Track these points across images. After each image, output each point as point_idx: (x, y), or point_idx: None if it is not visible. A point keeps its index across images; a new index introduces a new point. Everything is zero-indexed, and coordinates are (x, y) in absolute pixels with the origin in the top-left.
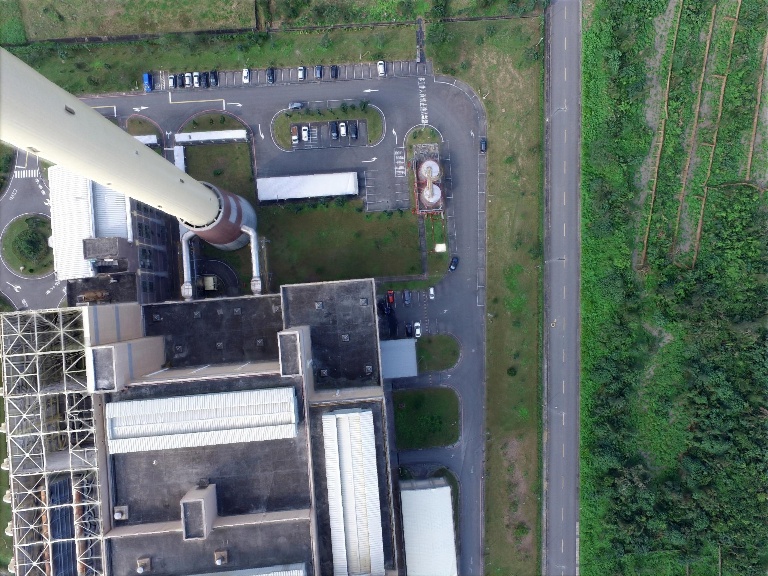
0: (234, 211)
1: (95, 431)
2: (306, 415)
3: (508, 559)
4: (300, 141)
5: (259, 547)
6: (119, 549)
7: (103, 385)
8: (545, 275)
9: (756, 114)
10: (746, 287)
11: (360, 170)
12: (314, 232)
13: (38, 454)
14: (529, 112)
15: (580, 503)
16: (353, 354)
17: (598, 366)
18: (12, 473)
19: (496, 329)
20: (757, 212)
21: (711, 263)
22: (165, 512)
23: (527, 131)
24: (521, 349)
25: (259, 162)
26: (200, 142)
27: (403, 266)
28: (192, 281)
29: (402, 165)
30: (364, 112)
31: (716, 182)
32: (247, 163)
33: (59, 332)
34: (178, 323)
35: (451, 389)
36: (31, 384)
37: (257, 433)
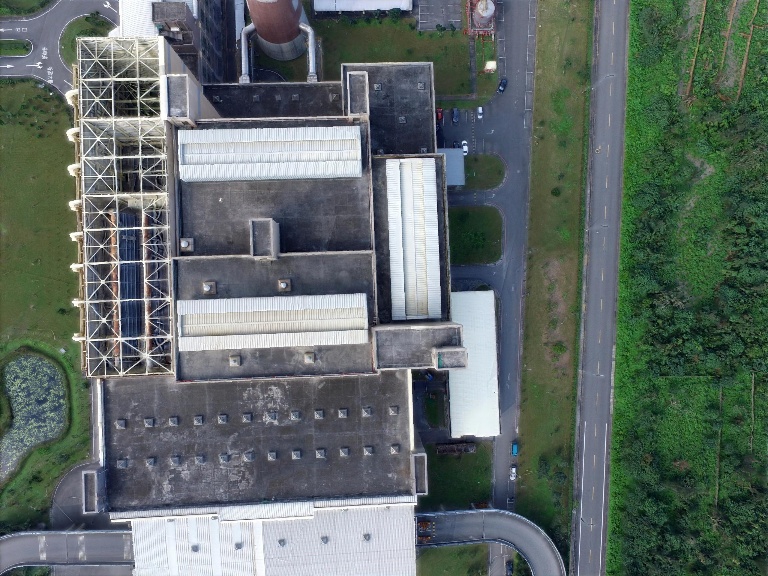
0: None
1: (166, 158)
2: (370, 160)
3: (545, 376)
4: None
5: (321, 279)
6: (185, 273)
7: (176, 113)
8: (591, 102)
9: None
10: None
11: None
12: (367, 47)
13: (110, 176)
14: None
15: (617, 326)
16: (409, 137)
17: (640, 191)
18: (84, 193)
19: (542, 151)
20: None
21: (755, 96)
22: (229, 248)
23: None
24: (565, 172)
25: None
26: None
27: (453, 85)
28: (249, 76)
29: None
30: None
31: (762, 22)
32: None
33: (135, 60)
34: (237, 106)
35: (495, 208)
36: (106, 108)
37: (324, 167)
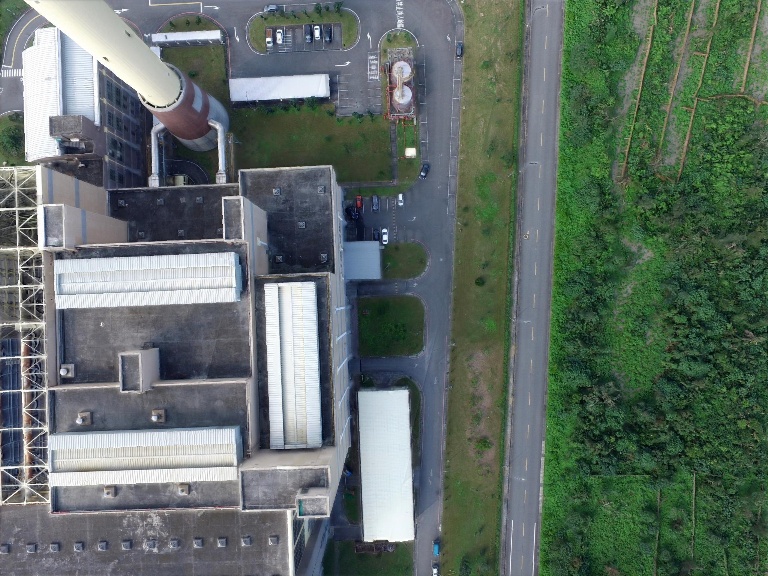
0: (199, 99)
1: (44, 287)
2: (249, 284)
3: (469, 473)
4: (274, 44)
5: (196, 409)
6: (62, 402)
7: (53, 242)
8: (519, 185)
9: (755, 22)
10: (735, 203)
11: (333, 74)
12: (285, 135)
13: None
14: (508, 17)
15: (547, 421)
16: (309, 242)
17: (571, 280)
18: None
19: (465, 238)
20: (752, 126)
21: (697, 176)
22: (110, 373)
23: (506, 36)
24: (491, 260)
25: (233, 65)
26: (176, 43)
27: (373, 172)
28: (160, 174)
29: (376, 70)
30: (339, 15)
31: (708, 94)
32: (222, 65)
33: (14, 190)
34: (142, 210)
35: (417, 298)
36: None
37: (198, 295)
